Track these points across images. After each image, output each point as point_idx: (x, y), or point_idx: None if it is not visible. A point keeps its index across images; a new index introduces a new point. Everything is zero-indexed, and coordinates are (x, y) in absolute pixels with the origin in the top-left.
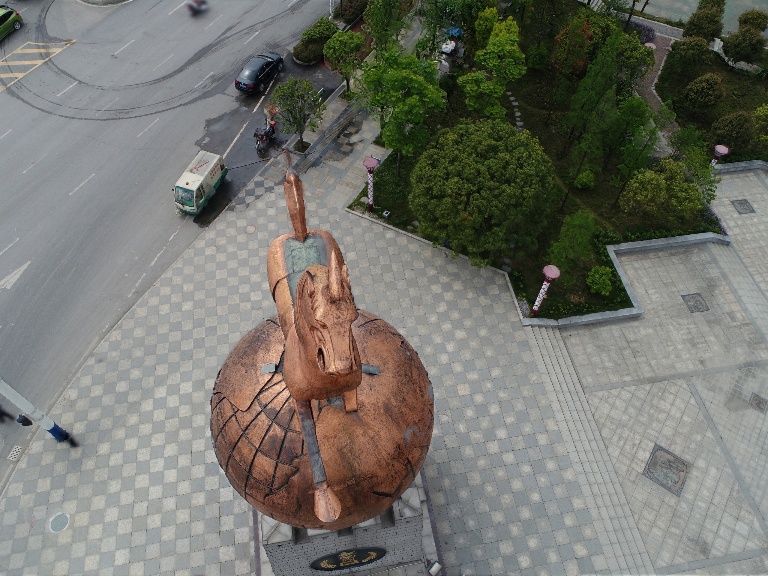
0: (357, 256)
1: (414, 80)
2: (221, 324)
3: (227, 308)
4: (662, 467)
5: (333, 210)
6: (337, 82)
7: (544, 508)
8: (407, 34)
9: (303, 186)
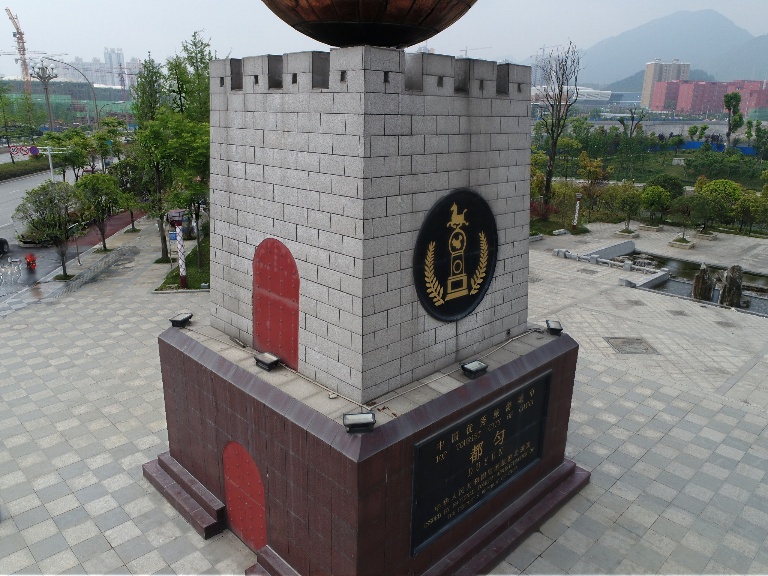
0: (191, 310)
1: (203, 128)
2: (8, 392)
3: (13, 379)
4: (625, 345)
5: (135, 297)
6: (85, 248)
7: (575, 380)
8: (148, 224)
9: (83, 293)
